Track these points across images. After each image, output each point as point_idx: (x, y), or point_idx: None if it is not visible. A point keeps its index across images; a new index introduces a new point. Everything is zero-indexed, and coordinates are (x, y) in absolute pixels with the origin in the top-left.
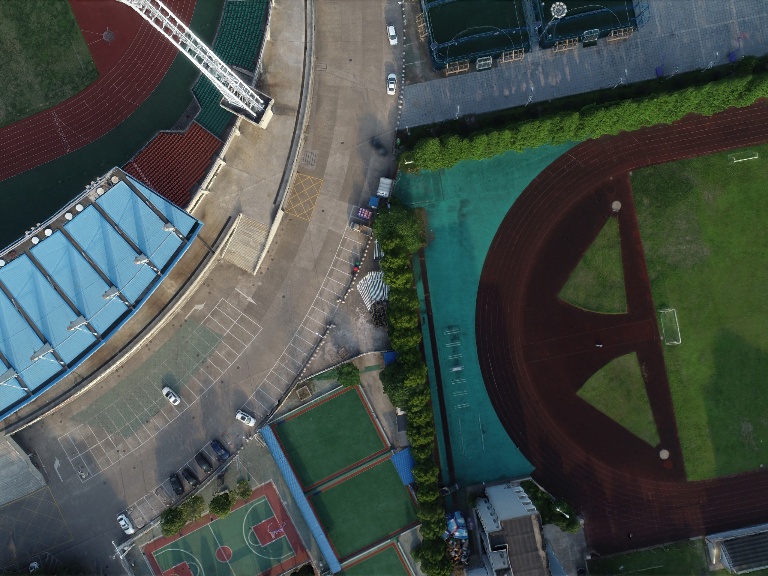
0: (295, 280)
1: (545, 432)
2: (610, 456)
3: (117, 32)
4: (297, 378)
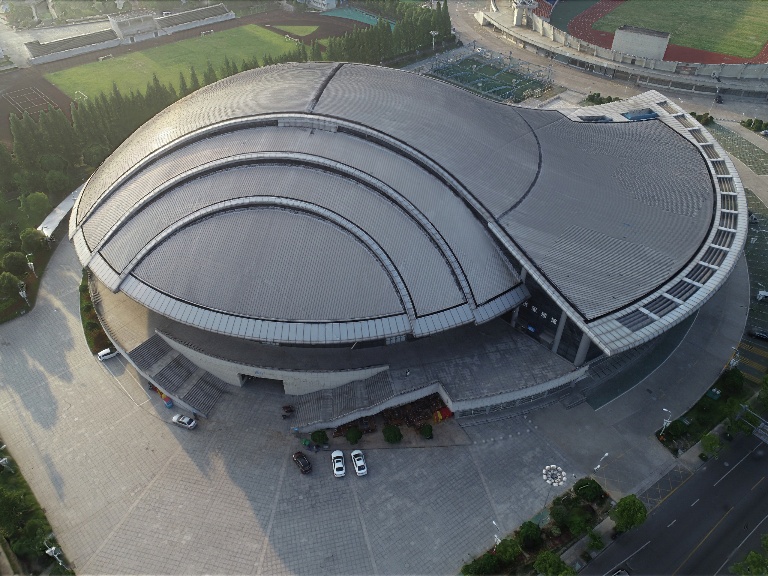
0: (458, 18)
1: (323, 19)
2: (291, 21)
3: (602, 36)
4: (431, 7)
